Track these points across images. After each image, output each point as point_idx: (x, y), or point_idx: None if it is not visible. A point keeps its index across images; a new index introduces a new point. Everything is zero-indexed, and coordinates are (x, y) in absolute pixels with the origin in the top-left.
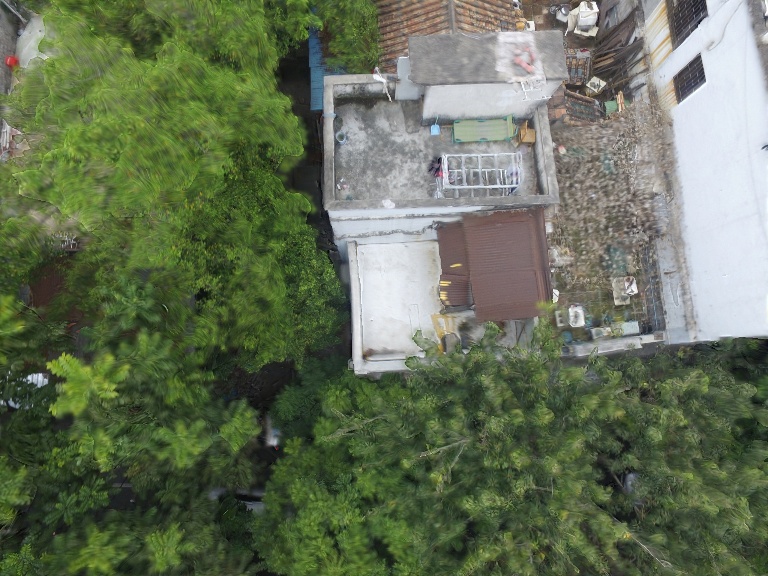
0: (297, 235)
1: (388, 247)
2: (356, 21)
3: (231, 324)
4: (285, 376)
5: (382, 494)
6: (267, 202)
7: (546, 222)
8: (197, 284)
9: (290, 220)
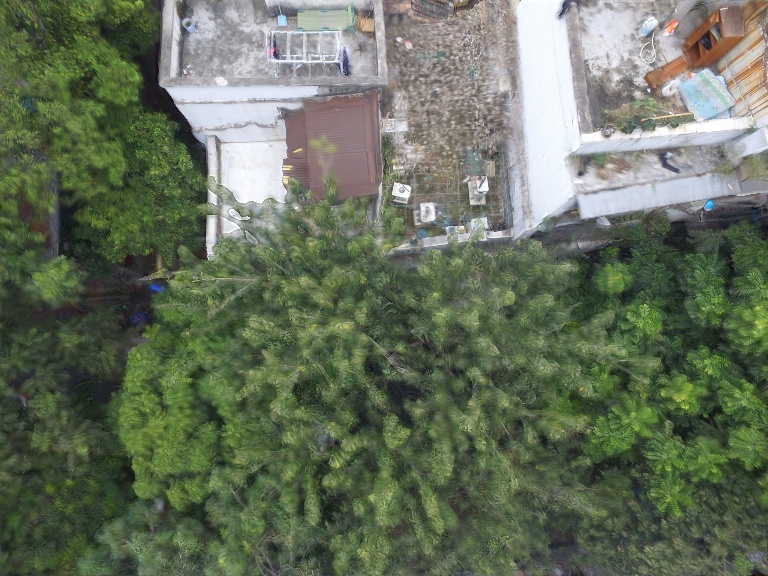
0: (148, 121)
1: (253, 146)
2: None
3: (56, 185)
4: (164, 279)
5: None
6: (88, 66)
7: (401, 121)
8: (9, 135)
9: (116, 88)
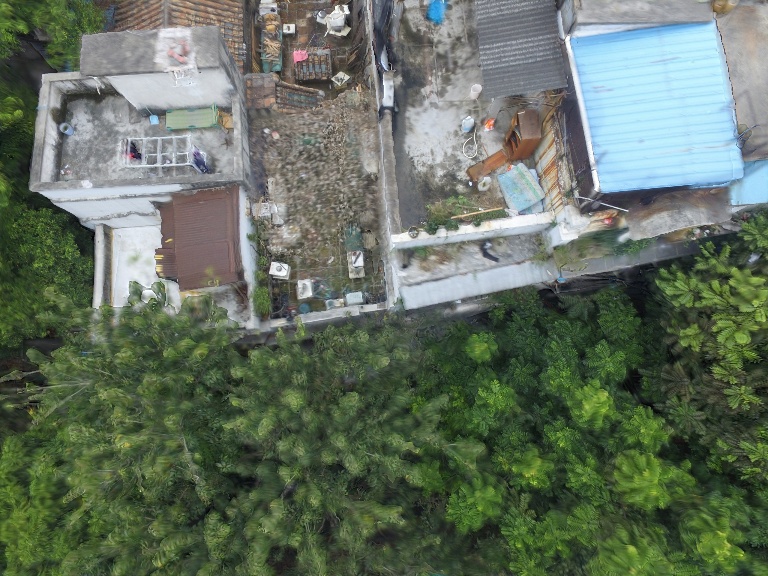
0: (32, 217)
1: (144, 230)
2: (68, 25)
3: None
4: None
5: None
6: None
7: None
8: None
9: None
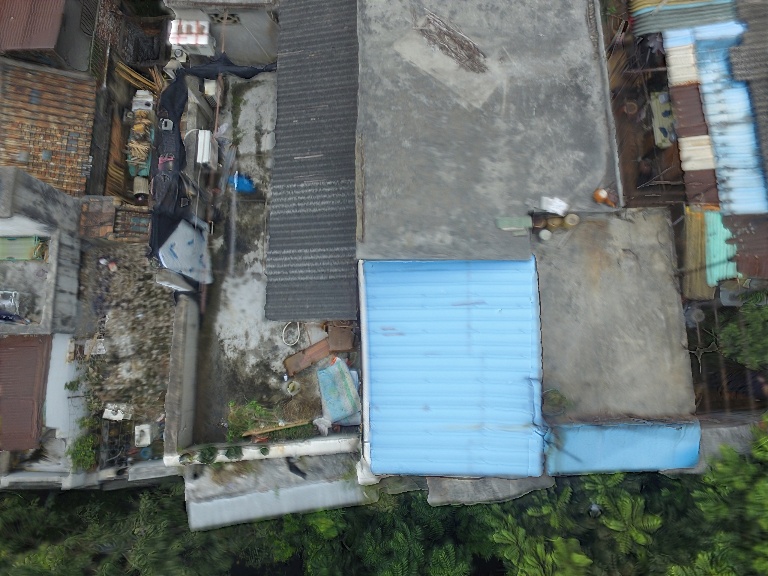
0: None
1: None
2: None
3: None
4: None
5: None
6: None
7: None
8: None
9: None
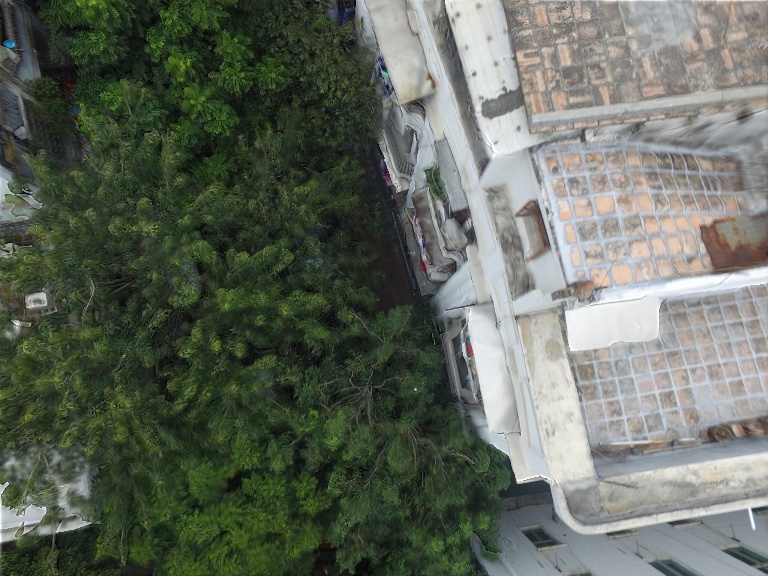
0: None
1: None
2: None
3: None
4: (148, 575)
5: None
6: None
7: None
8: None
9: None
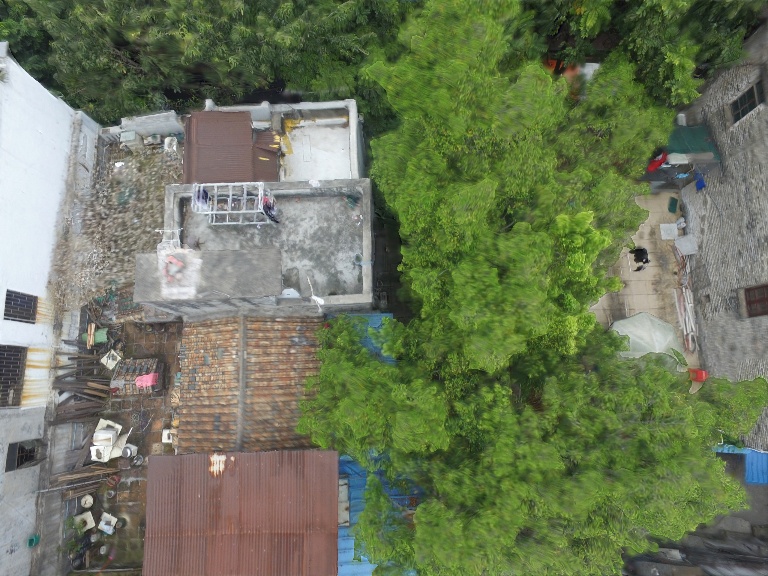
0: None
1: None
2: None
3: None
4: None
5: (332, 1)
6: None
7: None
8: None
9: None
